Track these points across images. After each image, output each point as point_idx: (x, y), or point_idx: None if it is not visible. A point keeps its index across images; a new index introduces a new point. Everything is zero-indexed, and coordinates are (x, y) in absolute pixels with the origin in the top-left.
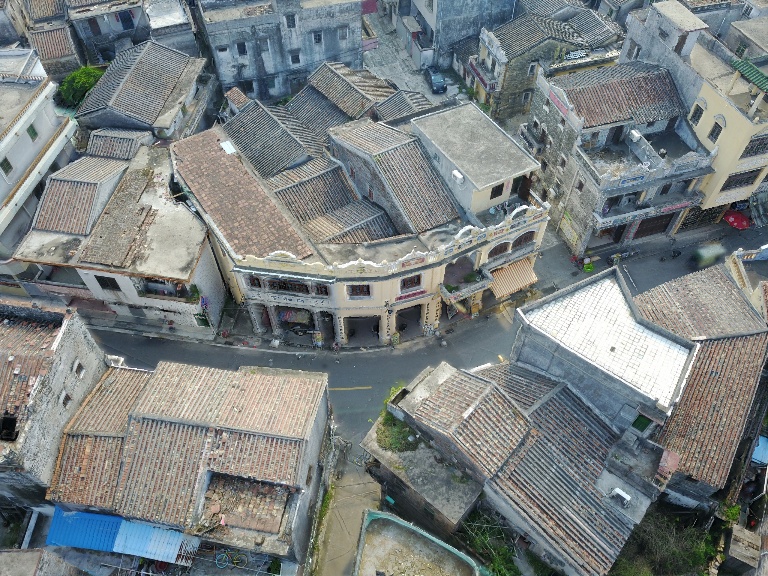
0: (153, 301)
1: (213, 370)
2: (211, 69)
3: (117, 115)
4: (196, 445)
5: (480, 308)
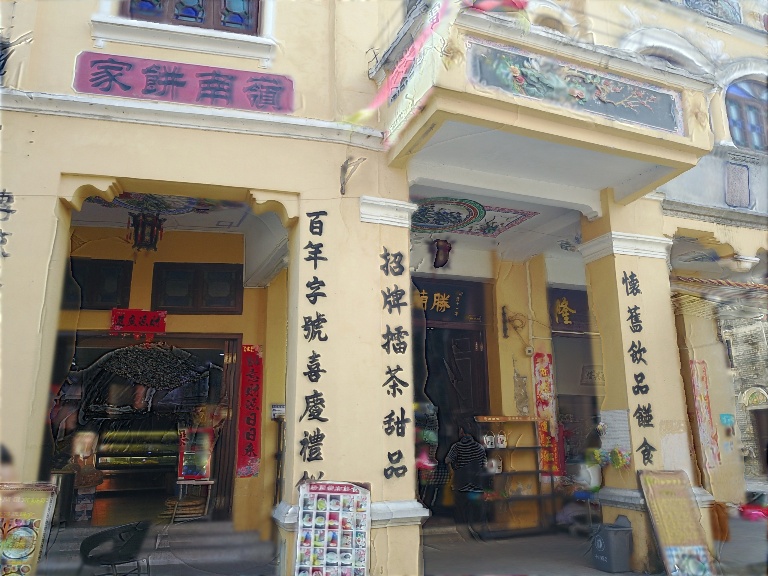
0: None
1: None
2: None
3: None
4: None
5: (709, 539)
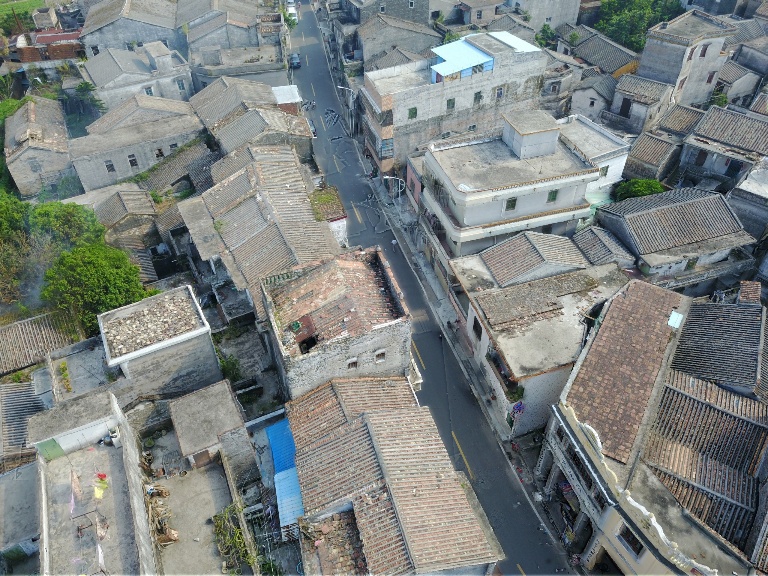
0: (490, 369)
1: (444, 451)
2: (762, 253)
3: (624, 228)
4: (366, 478)
5: None
